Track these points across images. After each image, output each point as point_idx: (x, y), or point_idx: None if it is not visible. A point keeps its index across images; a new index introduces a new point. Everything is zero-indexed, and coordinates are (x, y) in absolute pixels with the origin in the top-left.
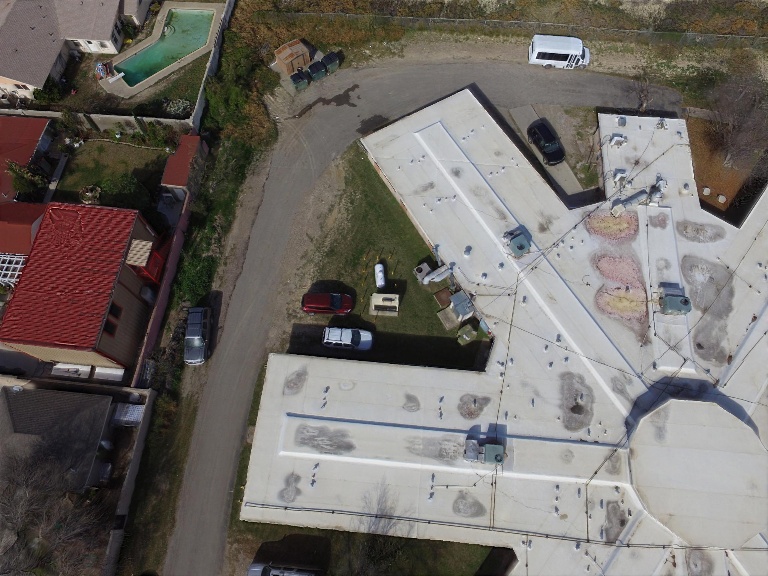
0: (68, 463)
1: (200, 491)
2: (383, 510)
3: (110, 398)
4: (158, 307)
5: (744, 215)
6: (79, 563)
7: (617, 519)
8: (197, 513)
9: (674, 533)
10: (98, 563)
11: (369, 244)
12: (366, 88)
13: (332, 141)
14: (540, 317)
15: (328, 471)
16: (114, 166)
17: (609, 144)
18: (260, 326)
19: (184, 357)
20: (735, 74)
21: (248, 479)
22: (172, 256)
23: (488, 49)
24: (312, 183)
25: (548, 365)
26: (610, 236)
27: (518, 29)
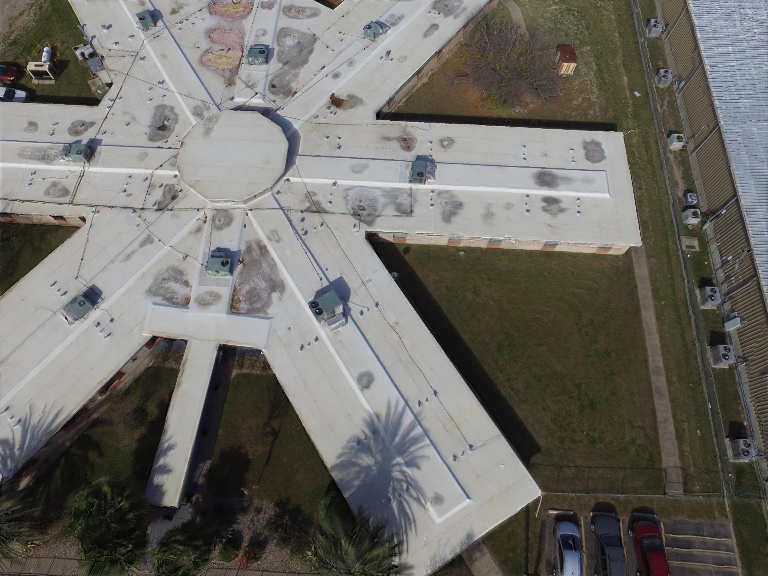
0: None
1: None
2: None
3: None
4: None
5: None
6: None
7: (170, 195)
8: None
9: (197, 192)
10: None
11: (46, 36)
12: None
13: None
14: (153, 70)
15: None
16: None
17: None
18: None
19: None
20: None
21: None
22: None
23: None
24: None
25: None
26: (227, 16)
27: None
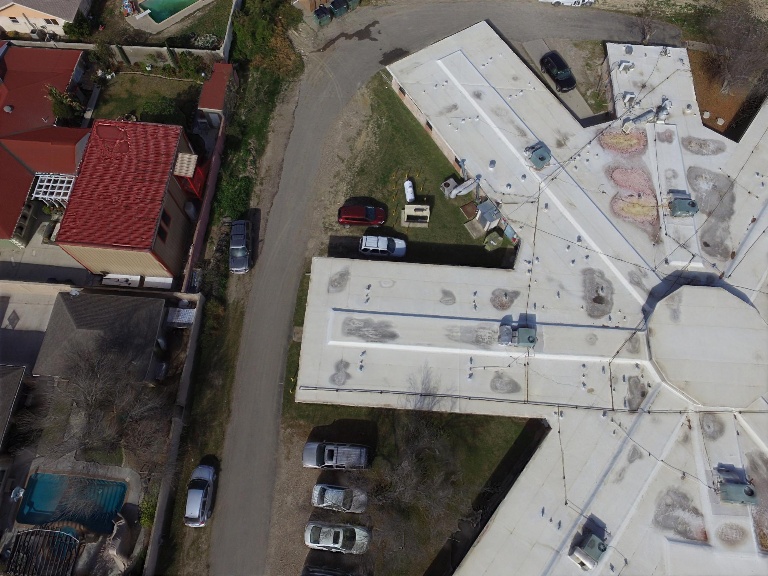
0: (129, 356)
1: (252, 384)
2: (427, 389)
3: (163, 301)
4: (201, 221)
5: (742, 131)
6: (151, 436)
7: (638, 391)
8: (250, 404)
9: (690, 397)
10: (158, 452)
11: (397, 164)
12: (386, 24)
13: (357, 72)
14: (561, 221)
15: (374, 357)
16: (147, 96)
17: (618, 70)
18: (299, 238)
19: (229, 266)
20: (729, 11)
21: (300, 366)
22: (212, 175)
23: None
24: (340, 110)
25: (571, 262)
26: (622, 150)
27: None
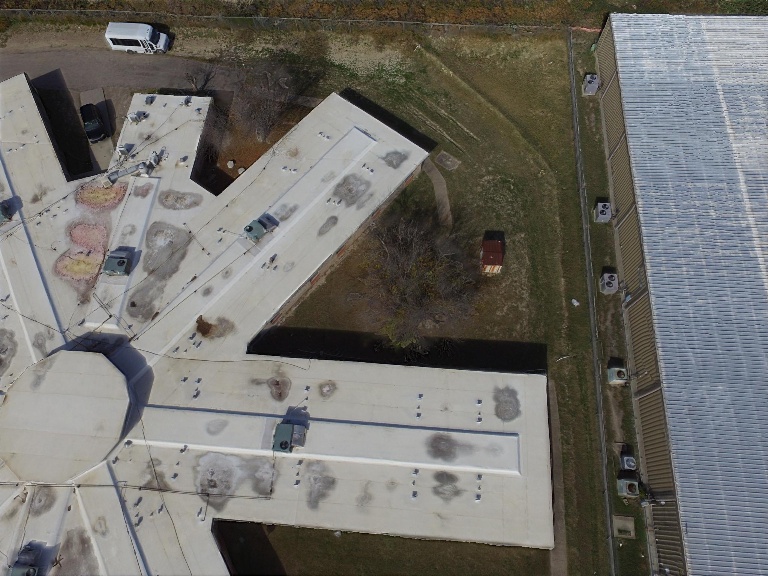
0: None
1: None
2: None
3: None
4: None
5: None
6: None
7: None
8: None
9: None
10: None
11: None
12: None
13: None
14: None
15: None
16: None
17: (129, 121)
18: None
19: None
20: (304, 55)
21: None
22: None
23: (85, 37)
24: None
25: None
26: (94, 205)
27: (110, 18)
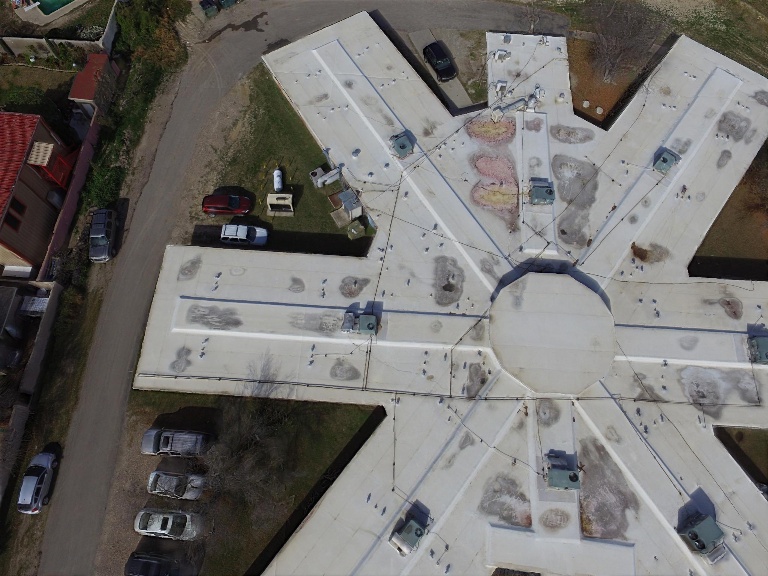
0: None
1: (102, 372)
2: (266, 376)
3: (14, 289)
4: (65, 210)
5: (613, 120)
6: None
7: (478, 378)
8: (98, 391)
9: (523, 383)
10: (5, 440)
11: (270, 154)
12: (274, 15)
13: (239, 63)
14: (420, 209)
15: (216, 345)
16: (28, 87)
17: (494, 59)
18: (164, 228)
19: (89, 255)
20: (620, 1)
21: (142, 354)
22: (79, 165)
23: None
24: (218, 100)
25: (424, 250)
26: (489, 139)
27: None
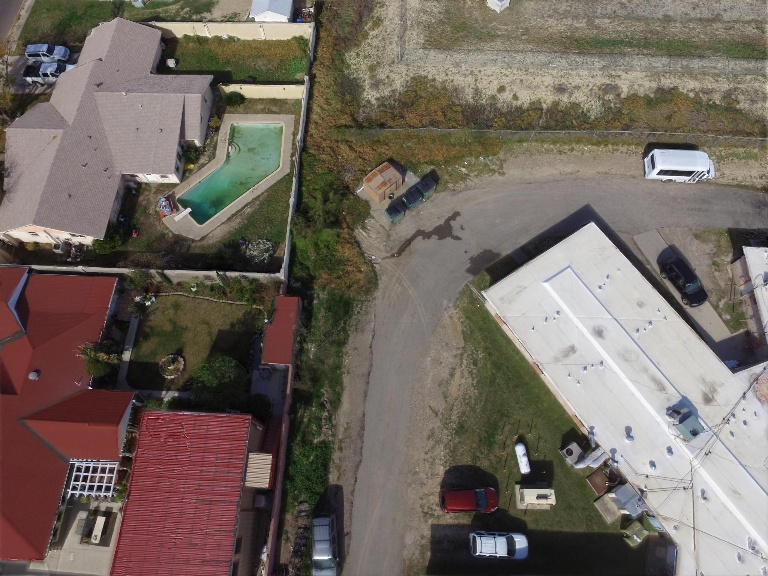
0: None
1: None
2: None
3: None
4: (275, 518)
5: None
6: None
7: None
8: None
9: None
10: None
11: (503, 416)
12: (469, 216)
13: (441, 285)
14: (724, 516)
15: None
16: (194, 328)
17: (763, 286)
18: (393, 530)
19: None
20: None
21: None
22: (282, 449)
23: (597, 161)
24: (426, 340)
25: None
26: None
27: (630, 138)
